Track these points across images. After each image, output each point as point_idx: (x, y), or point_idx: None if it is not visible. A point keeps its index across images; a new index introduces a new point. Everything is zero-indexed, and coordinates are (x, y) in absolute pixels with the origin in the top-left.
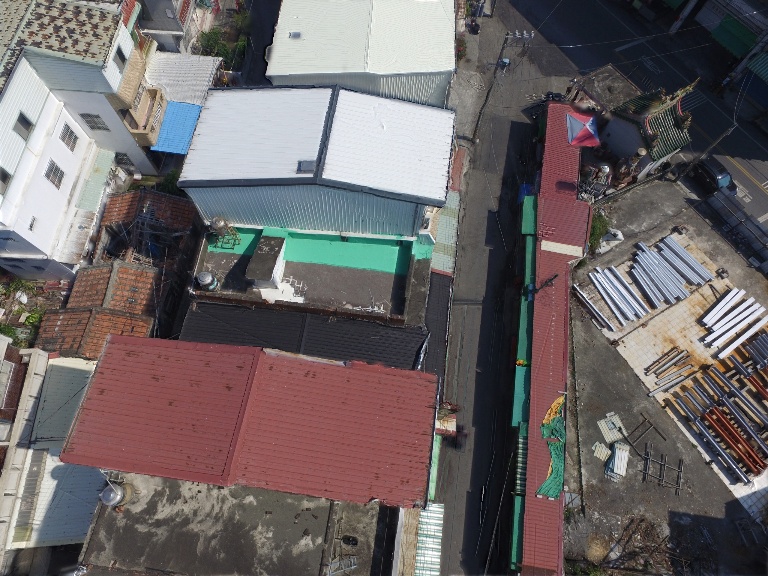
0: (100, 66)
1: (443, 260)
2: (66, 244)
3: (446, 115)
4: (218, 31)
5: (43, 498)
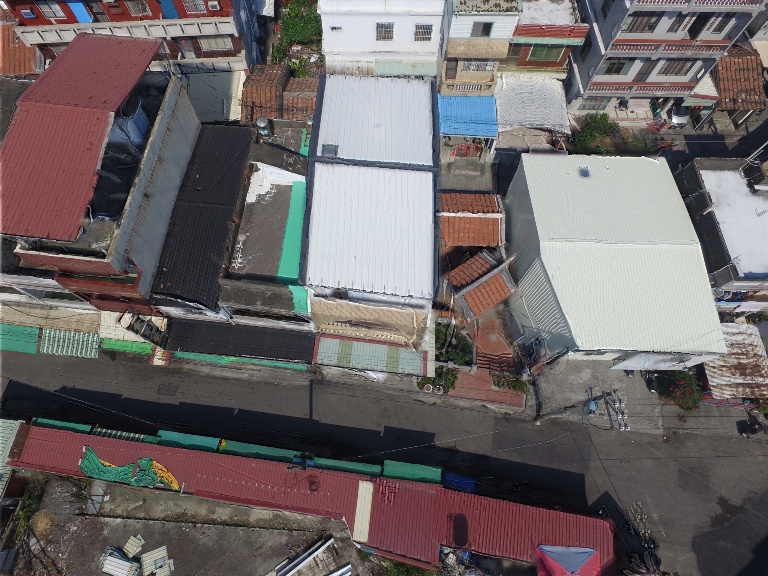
0: (453, 10)
1: (331, 352)
2: (342, 62)
3: (426, 287)
4: (625, 134)
5: None
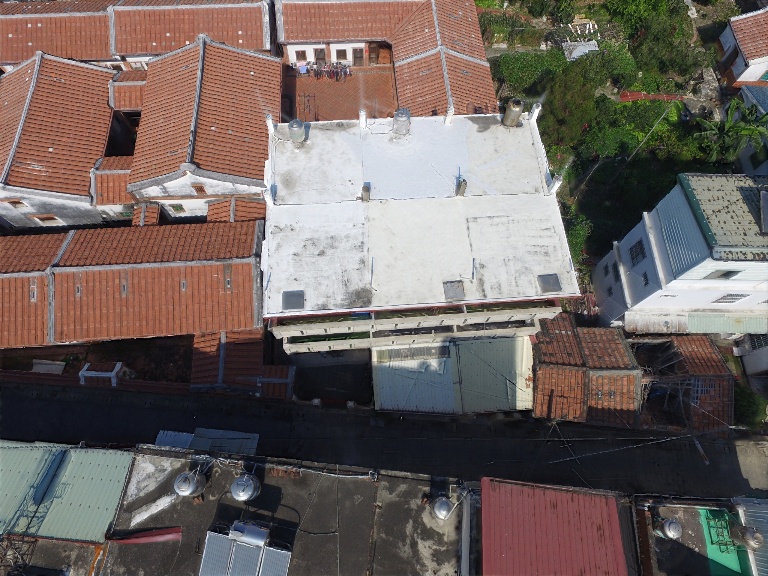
0: None
1: None
2: (645, 315)
3: None
4: None
5: (410, 364)
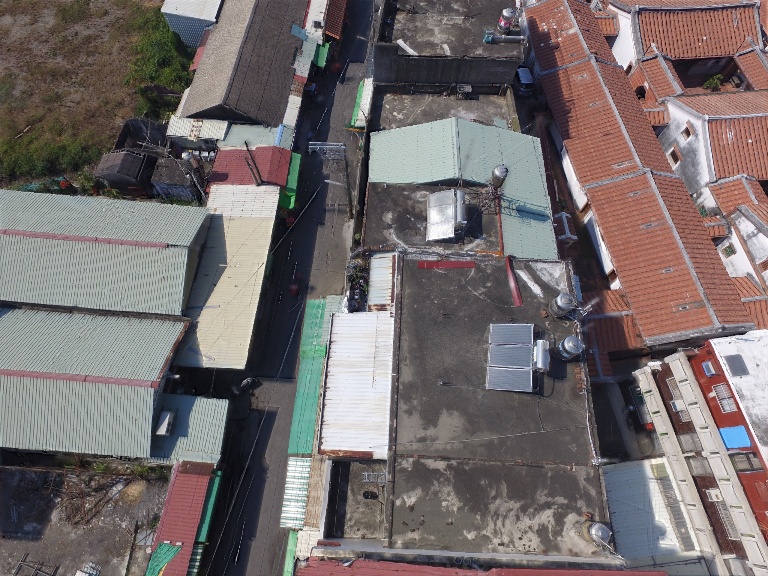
0: None
1: None
2: None
3: None
4: None
5: (660, 502)
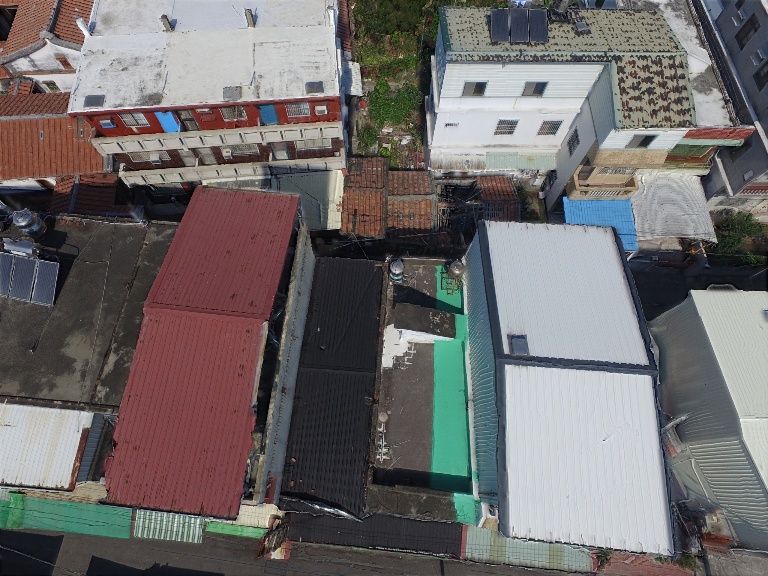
0: (616, 125)
1: (482, 544)
2: (448, 155)
3: (663, 540)
4: (767, 232)
5: None
